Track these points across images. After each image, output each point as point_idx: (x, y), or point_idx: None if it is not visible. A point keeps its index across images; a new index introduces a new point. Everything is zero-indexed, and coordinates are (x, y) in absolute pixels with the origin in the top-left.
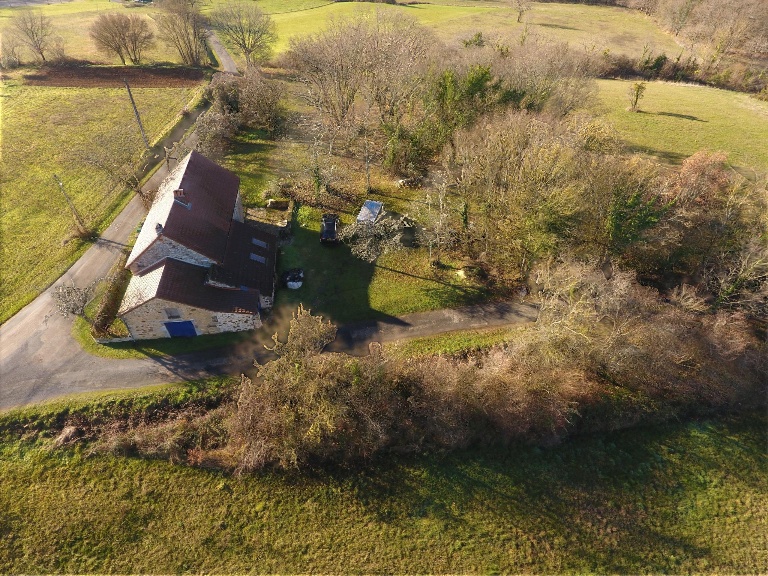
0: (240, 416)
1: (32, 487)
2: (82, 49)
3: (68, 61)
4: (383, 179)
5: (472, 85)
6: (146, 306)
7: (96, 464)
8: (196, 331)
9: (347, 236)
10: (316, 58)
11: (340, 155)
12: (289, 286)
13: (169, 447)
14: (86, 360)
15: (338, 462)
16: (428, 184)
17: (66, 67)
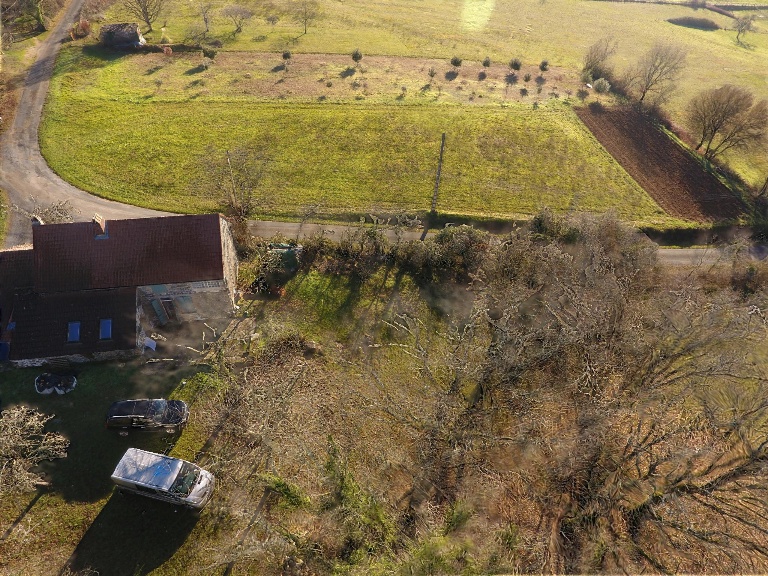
0: None
1: None
2: None
3: (656, 112)
4: None
5: None
6: None
7: None
8: None
9: None
10: (615, 297)
11: None
12: None
13: None
14: None
15: None
16: None
17: (641, 116)
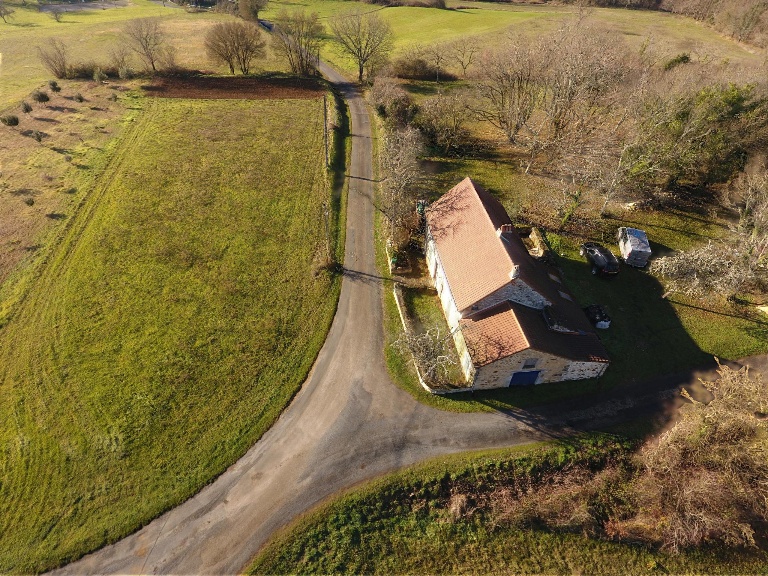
0: (659, 484)
1: (456, 570)
2: (177, 57)
3: (178, 71)
4: (603, 201)
5: (728, 105)
6: (511, 357)
7: (505, 539)
8: (538, 380)
9: (669, 272)
10: (507, 72)
11: (537, 174)
12: (598, 326)
13: (585, 520)
14: (430, 414)
15: (760, 533)
16: (659, 207)
17: (178, 77)
